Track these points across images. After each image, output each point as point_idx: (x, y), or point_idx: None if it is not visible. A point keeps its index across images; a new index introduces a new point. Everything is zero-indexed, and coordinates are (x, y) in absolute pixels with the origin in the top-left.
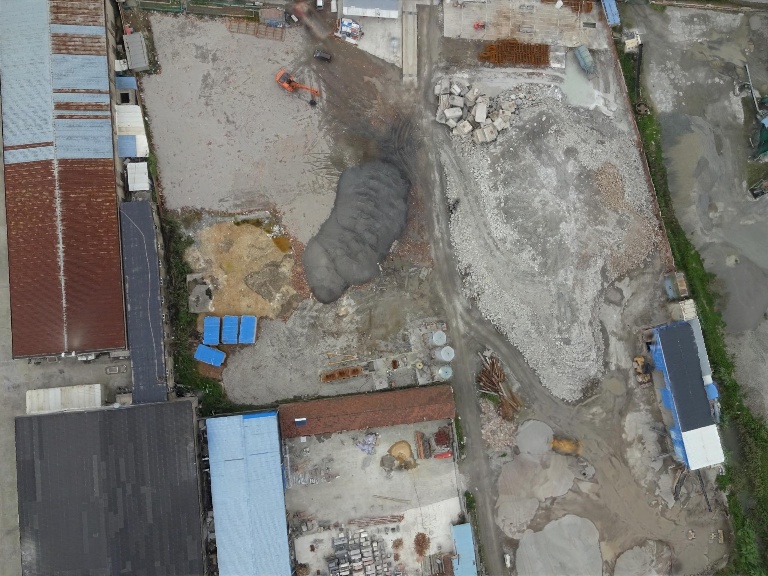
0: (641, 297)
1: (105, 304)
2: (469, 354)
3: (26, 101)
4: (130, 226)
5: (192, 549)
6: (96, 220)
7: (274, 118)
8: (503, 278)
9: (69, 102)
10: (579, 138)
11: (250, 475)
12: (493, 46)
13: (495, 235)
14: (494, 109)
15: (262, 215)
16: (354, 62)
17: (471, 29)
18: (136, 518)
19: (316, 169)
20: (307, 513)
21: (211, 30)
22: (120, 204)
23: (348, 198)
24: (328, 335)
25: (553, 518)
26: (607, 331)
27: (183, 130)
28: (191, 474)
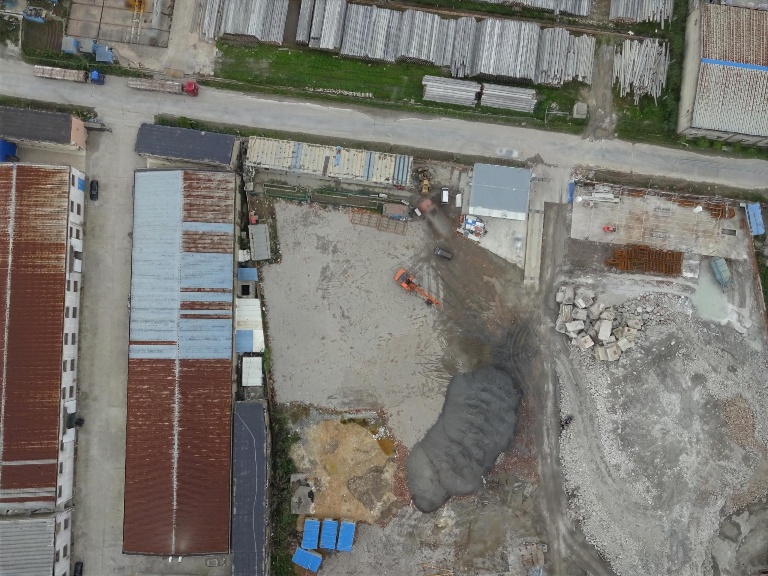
0: (760, 535)
1: (213, 507)
2: None
3: (154, 297)
4: (242, 428)
5: None
6: (211, 421)
7: (389, 315)
8: (613, 508)
9: (194, 301)
10: (710, 367)
11: None
12: (623, 253)
13: (608, 460)
14: (618, 323)
15: (369, 415)
16: (475, 260)
17: (600, 231)
18: None
19: (427, 371)
20: None
21: (334, 220)
22: (234, 405)
23: (458, 408)
24: (425, 546)
25: None
26: (719, 568)
27: (298, 323)
28: None
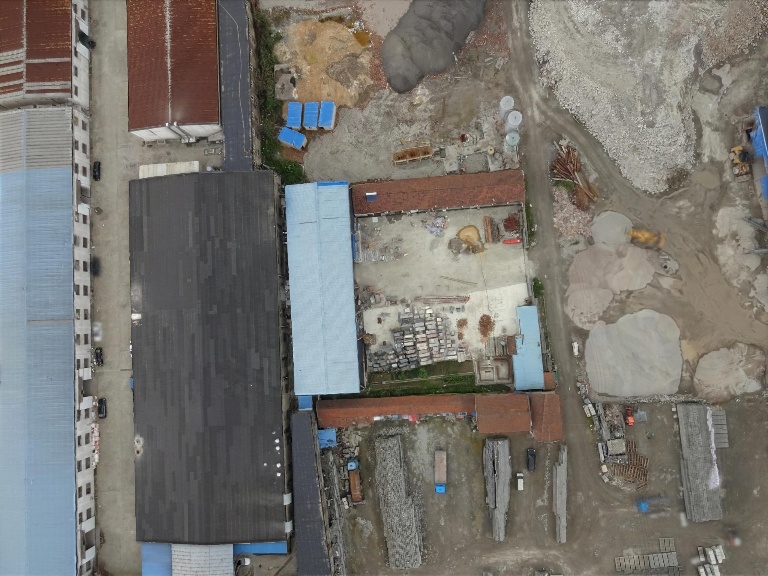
0: (743, 84)
1: (203, 84)
2: (544, 143)
3: None
4: (226, 17)
5: (269, 302)
6: (198, 11)
7: None
8: (582, 61)
9: None
10: None
11: (322, 237)
12: None
13: (576, 19)
14: None
15: (344, 12)
16: None
17: None
18: (222, 269)
19: None
20: (376, 288)
21: None
22: None
23: None
24: (402, 123)
25: (628, 312)
26: (700, 121)
27: None
28: (271, 236)
